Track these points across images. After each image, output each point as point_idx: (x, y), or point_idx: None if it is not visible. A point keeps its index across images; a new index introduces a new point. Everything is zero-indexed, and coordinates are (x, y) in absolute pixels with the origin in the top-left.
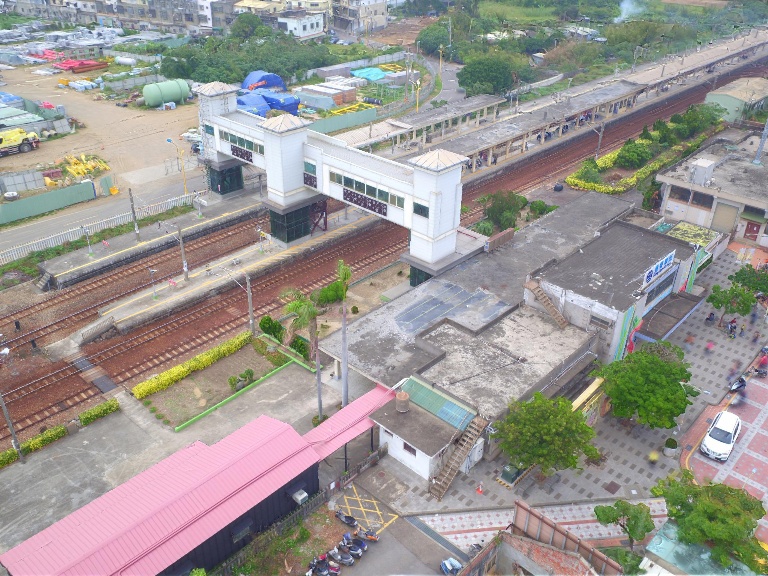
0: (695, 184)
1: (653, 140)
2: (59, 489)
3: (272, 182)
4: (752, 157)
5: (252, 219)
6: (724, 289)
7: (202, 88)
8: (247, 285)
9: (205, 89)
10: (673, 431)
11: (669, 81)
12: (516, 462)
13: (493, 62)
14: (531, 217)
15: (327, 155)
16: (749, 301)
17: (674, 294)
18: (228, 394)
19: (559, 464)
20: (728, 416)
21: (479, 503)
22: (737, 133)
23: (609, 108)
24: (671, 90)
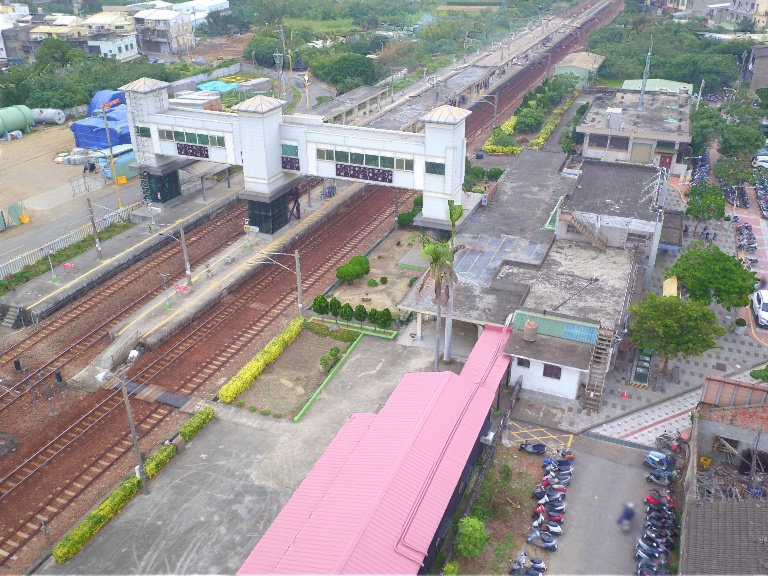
0: (613, 129)
1: None
2: (213, 506)
3: (251, 170)
4: (632, 107)
5: (207, 223)
6: (674, 209)
7: (131, 86)
8: (297, 265)
9: (136, 86)
10: (737, 313)
11: (504, 65)
12: (664, 355)
13: (357, 57)
14: (476, 181)
15: (313, 132)
16: (722, 206)
17: None
18: (320, 377)
19: (704, 346)
20: (766, 293)
21: (632, 406)
22: (589, 97)
23: (474, 89)
24: (507, 73)
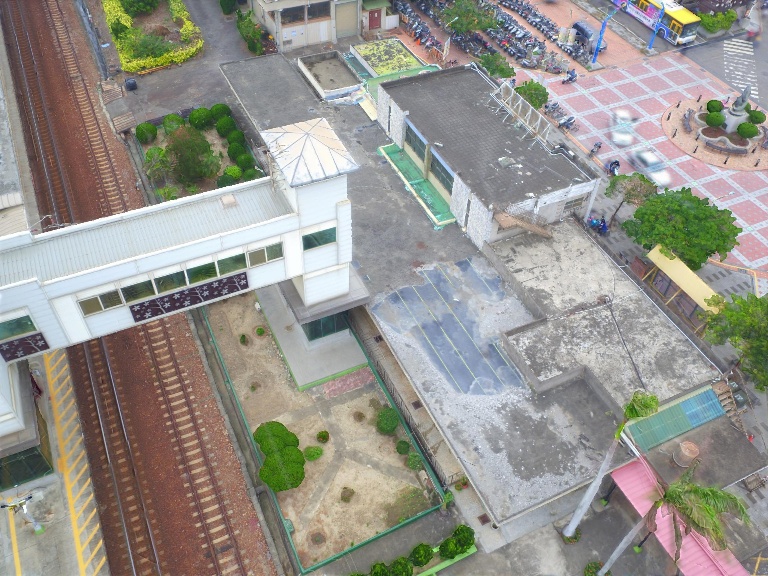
0: None
1: None
2: None
3: None
4: None
5: None
6: None
7: None
8: None
9: None
10: None
11: None
12: None
13: None
14: None
15: (58, 280)
16: None
17: None
18: None
19: None
20: None
21: (767, 448)
22: None
23: None
24: None
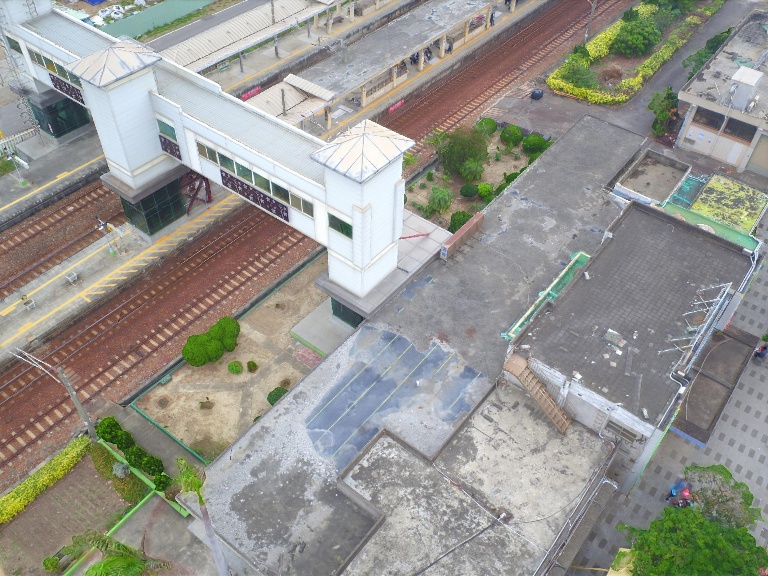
0: (734, 109)
1: (660, 5)
2: None
3: (110, 153)
4: None
5: None
6: None
7: None
8: None
9: None
10: None
11: None
12: None
13: None
14: (502, 153)
15: (188, 117)
16: None
17: (718, 332)
18: None
19: None
20: None
21: None
22: None
23: None
24: None
